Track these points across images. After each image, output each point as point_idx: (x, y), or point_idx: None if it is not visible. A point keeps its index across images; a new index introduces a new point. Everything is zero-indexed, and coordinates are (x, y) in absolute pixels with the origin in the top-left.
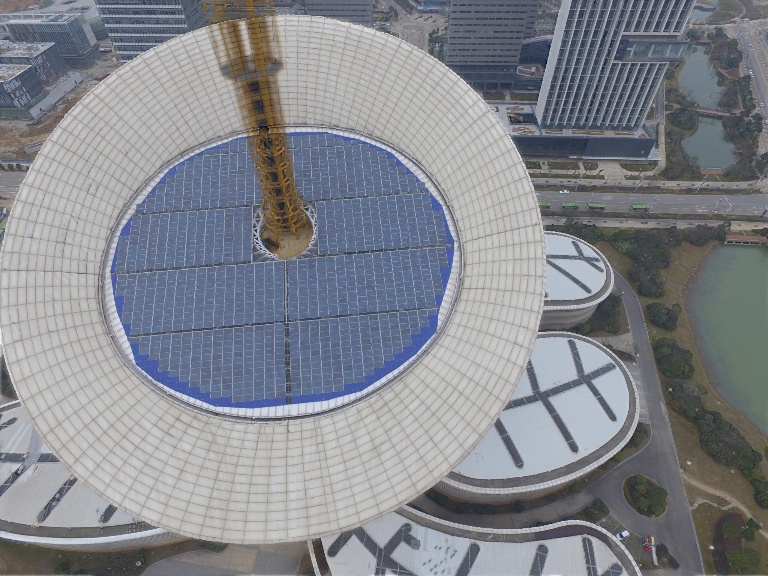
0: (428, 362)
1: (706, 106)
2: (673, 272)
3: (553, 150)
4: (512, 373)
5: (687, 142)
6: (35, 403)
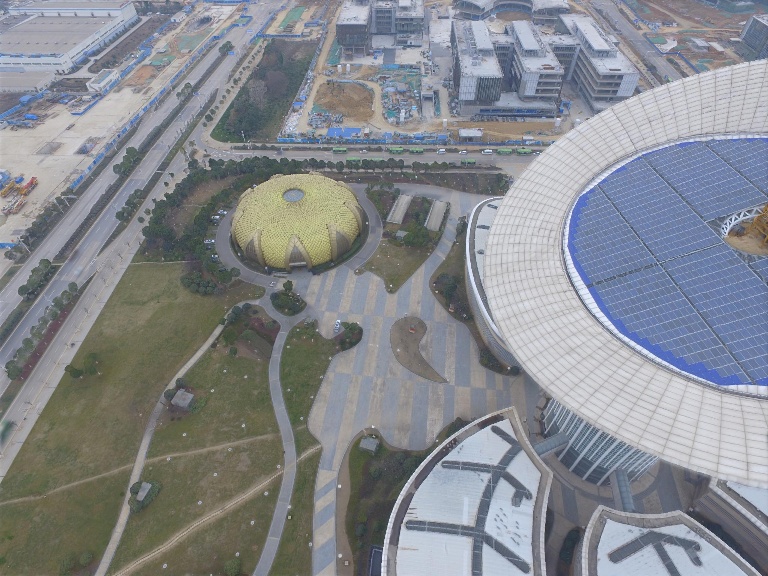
0: (677, 381)
1: None
2: None
3: None
4: (704, 461)
5: None
6: (536, 165)
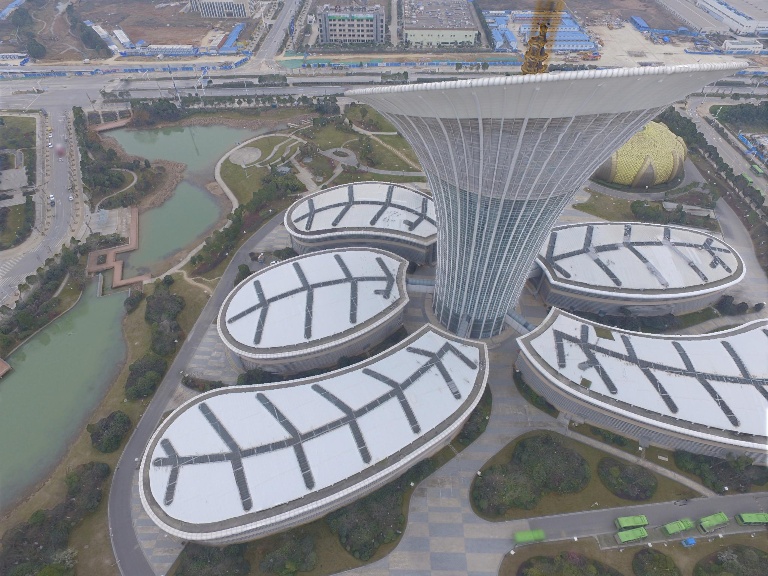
0: None
1: None
2: None
3: None
4: None
5: None
6: None
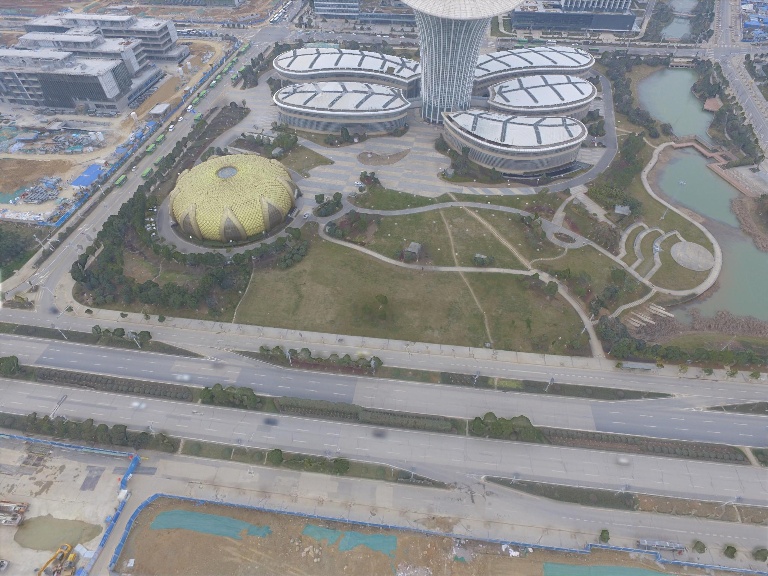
0: None
1: (680, 10)
2: (633, 74)
3: (571, 24)
4: None
5: (664, 32)
6: None
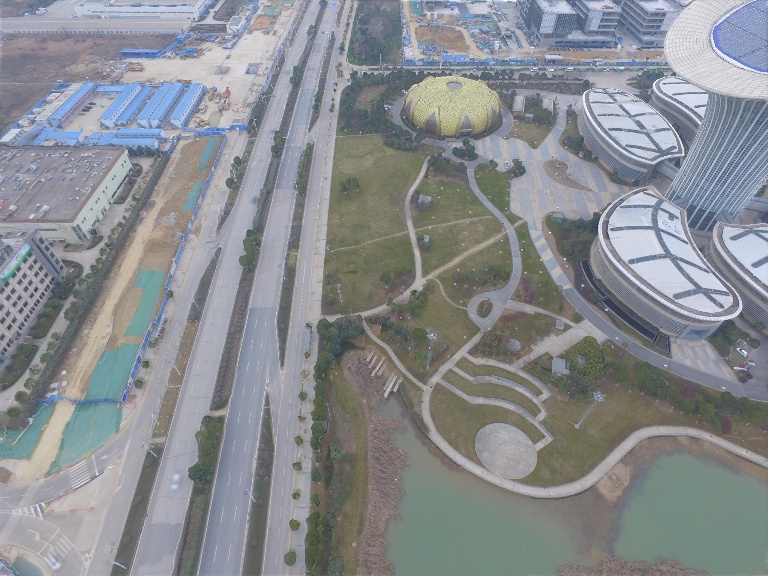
0: None
1: None
2: None
3: None
4: None
5: None
6: (683, 15)
